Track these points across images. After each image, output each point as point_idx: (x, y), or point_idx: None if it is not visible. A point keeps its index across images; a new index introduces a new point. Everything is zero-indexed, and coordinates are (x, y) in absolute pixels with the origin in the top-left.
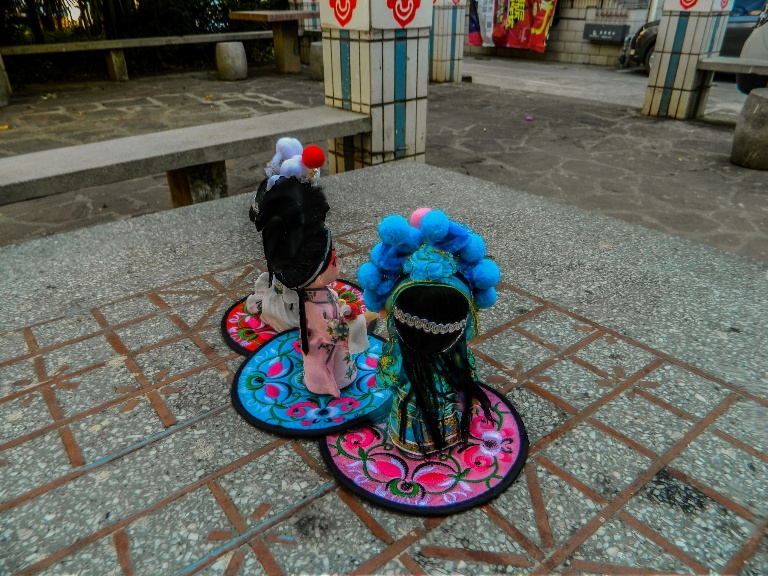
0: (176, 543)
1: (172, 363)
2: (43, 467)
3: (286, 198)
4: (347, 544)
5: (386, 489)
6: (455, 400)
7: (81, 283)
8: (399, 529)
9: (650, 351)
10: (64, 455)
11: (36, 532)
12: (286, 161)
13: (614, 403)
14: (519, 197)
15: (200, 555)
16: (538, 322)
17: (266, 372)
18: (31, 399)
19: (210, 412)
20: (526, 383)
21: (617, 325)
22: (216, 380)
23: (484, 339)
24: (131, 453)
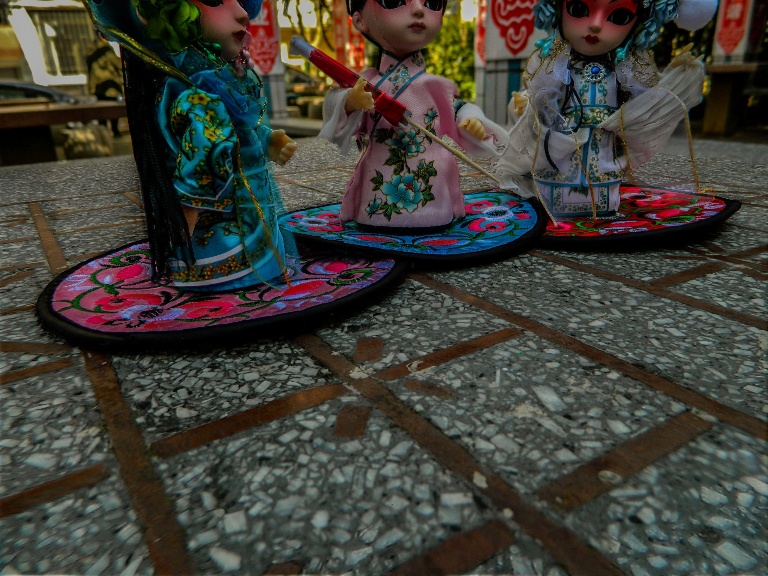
0: None
1: None
2: None
3: None
4: None
5: (141, 249)
6: None
7: None
8: None
9: None
10: None
11: None
12: None
13: (127, 572)
14: None
15: None
16: None
17: None
18: None
19: None
20: (340, 387)
21: None
22: None
23: (580, 352)
24: None
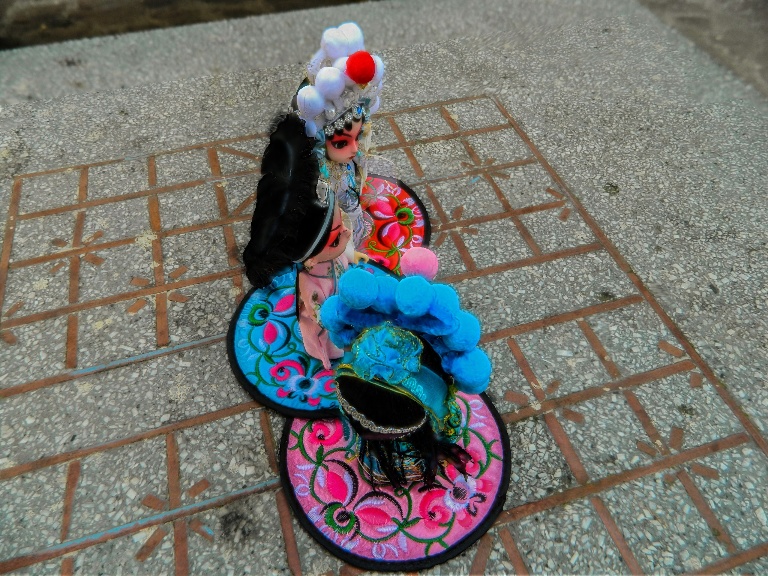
0: (115, 496)
1: (193, 259)
2: (43, 358)
3: (286, 152)
4: (258, 562)
5: (321, 513)
6: (419, 456)
7: (152, 114)
8: (313, 566)
9: (739, 417)
10: (63, 350)
11: (15, 434)
12: (323, 70)
13: (640, 485)
14: (714, 80)
15: (129, 518)
16: (616, 321)
17: (274, 304)
18: (59, 267)
19: (203, 340)
20: (549, 415)
21: (719, 358)
22: (225, 298)
23: (534, 329)
24: (117, 369)
